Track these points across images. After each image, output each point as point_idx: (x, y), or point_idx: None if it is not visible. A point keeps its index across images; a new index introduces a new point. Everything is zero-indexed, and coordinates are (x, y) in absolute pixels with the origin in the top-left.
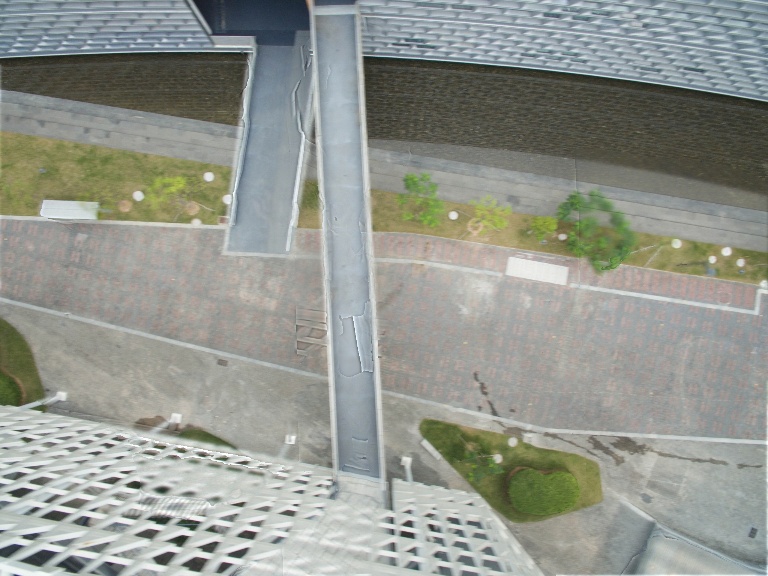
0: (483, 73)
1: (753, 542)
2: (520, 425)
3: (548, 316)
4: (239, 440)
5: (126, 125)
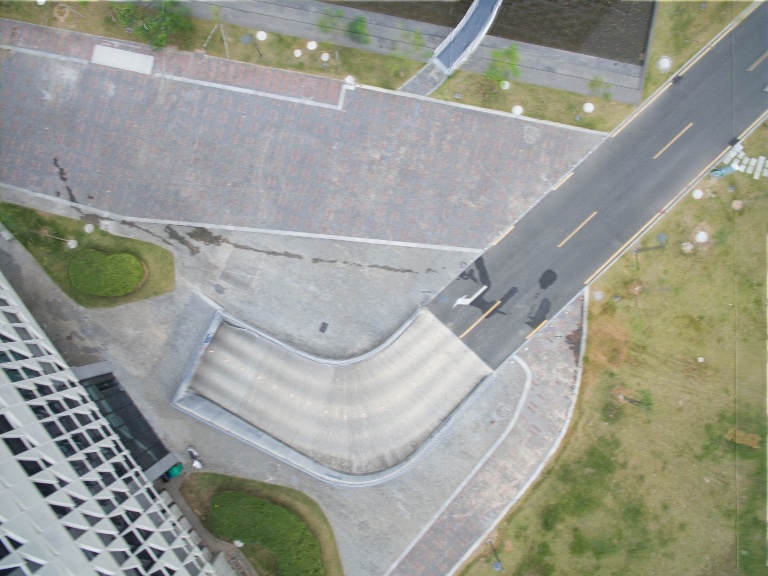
0: None
1: (324, 337)
2: (98, 212)
3: (131, 105)
4: None
5: None
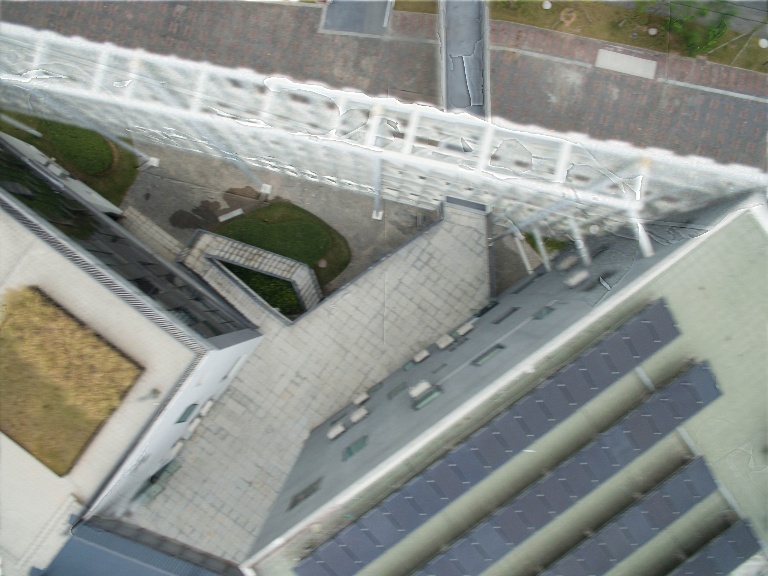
0: None
1: None
2: (602, 213)
3: (635, 108)
4: (327, 214)
5: None
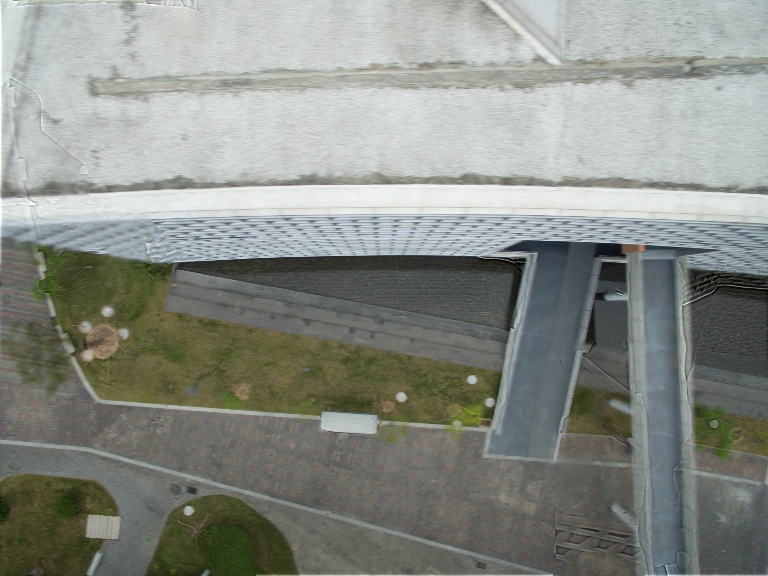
0: (762, 295)
1: None
2: None
3: None
4: None
5: (390, 325)
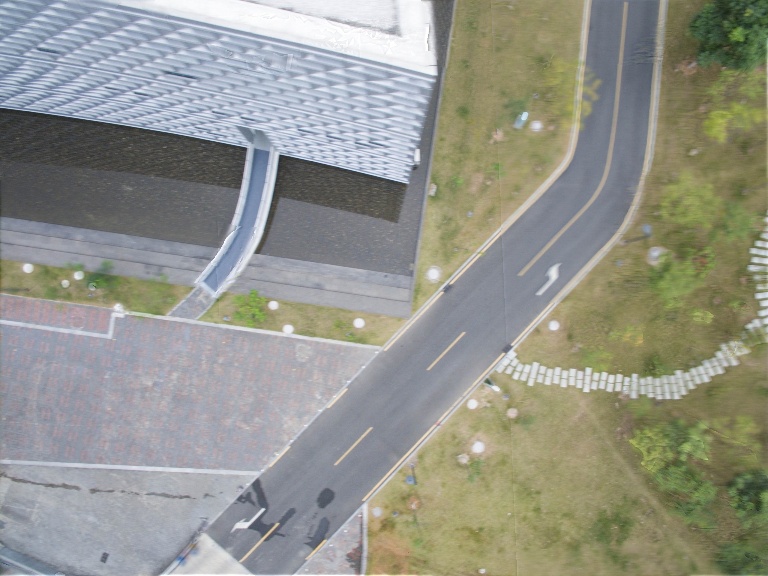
0: None
1: (105, 567)
2: None
3: None
4: None
5: None
